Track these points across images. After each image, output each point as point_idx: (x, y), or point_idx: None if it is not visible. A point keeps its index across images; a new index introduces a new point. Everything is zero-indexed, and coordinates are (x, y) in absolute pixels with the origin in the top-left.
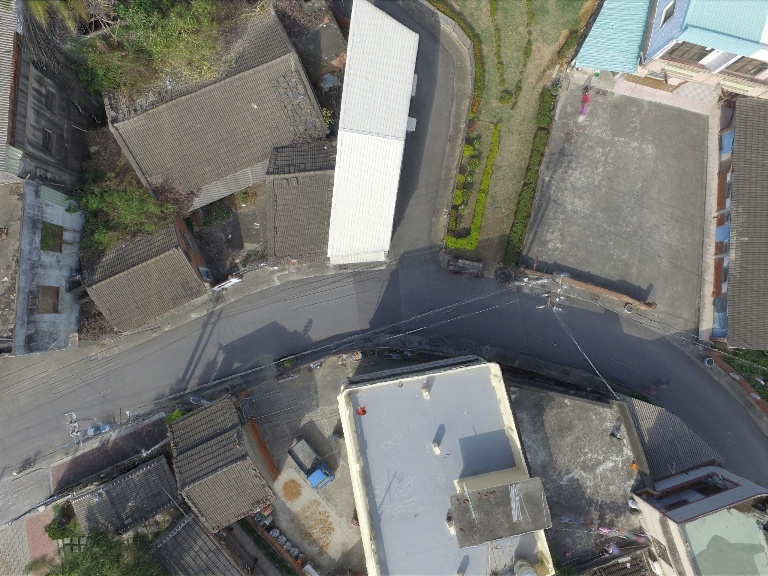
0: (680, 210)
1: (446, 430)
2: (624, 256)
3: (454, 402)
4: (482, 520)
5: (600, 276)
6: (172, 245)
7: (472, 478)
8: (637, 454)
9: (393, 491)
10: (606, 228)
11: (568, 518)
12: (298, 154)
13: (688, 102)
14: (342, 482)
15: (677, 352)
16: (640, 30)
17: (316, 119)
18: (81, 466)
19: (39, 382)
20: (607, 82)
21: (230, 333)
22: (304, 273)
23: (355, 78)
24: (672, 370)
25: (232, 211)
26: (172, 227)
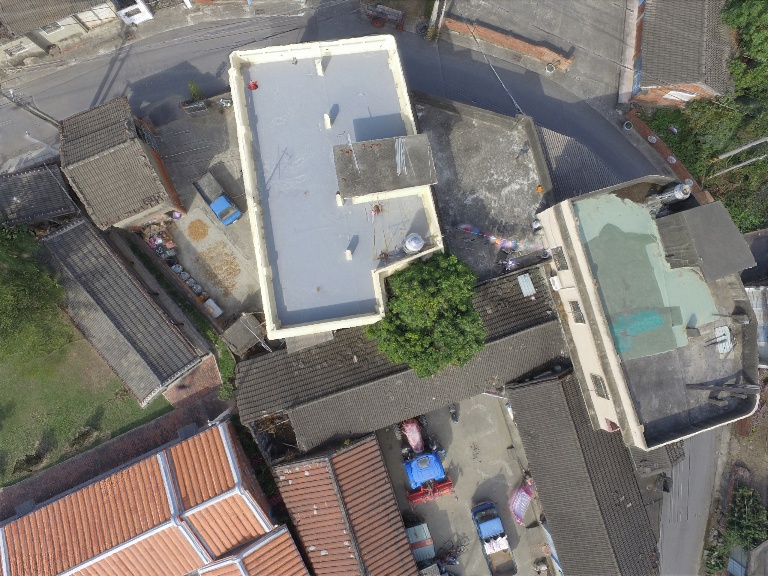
0: None
1: (340, 110)
2: (547, 16)
3: (350, 83)
4: (365, 171)
5: (522, 35)
6: None
7: None
8: (542, 174)
9: (283, 167)
10: None
11: (471, 237)
12: None
13: None
14: None
15: (597, 116)
16: None
17: None
18: None
19: None
20: None
21: (139, 70)
22: (219, 15)
23: None
24: (591, 134)
25: None
26: None
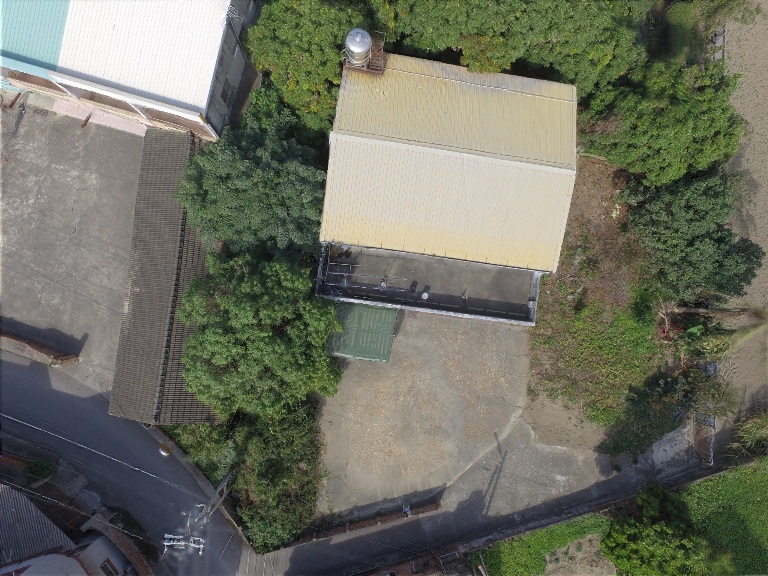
0: (125, 250)
1: None
2: (54, 301)
3: None
4: None
5: (25, 323)
6: None
7: None
8: None
9: None
10: (34, 268)
11: None
12: None
13: (142, 127)
14: None
15: None
16: None
17: None
18: None
19: None
20: (46, 100)
21: None
22: None
23: None
24: (107, 432)
25: None
26: None
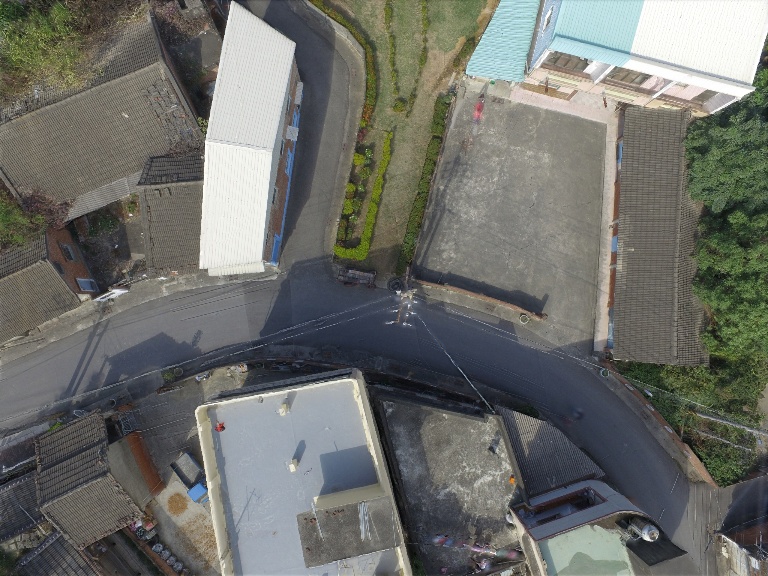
0: (576, 220)
1: (307, 446)
2: (519, 266)
3: (315, 418)
4: (330, 539)
5: (495, 286)
6: (40, 257)
7: (332, 495)
8: (514, 468)
9: (251, 508)
10: (501, 238)
11: (444, 533)
12: (173, 164)
13: (585, 110)
14: None
15: None
16: (529, 38)
17: (192, 128)
18: None
19: None
20: (503, 90)
21: (117, 345)
22: (193, 283)
23: (226, 87)
24: (567, 381)
25: (119, 221)
26: (43, 238)
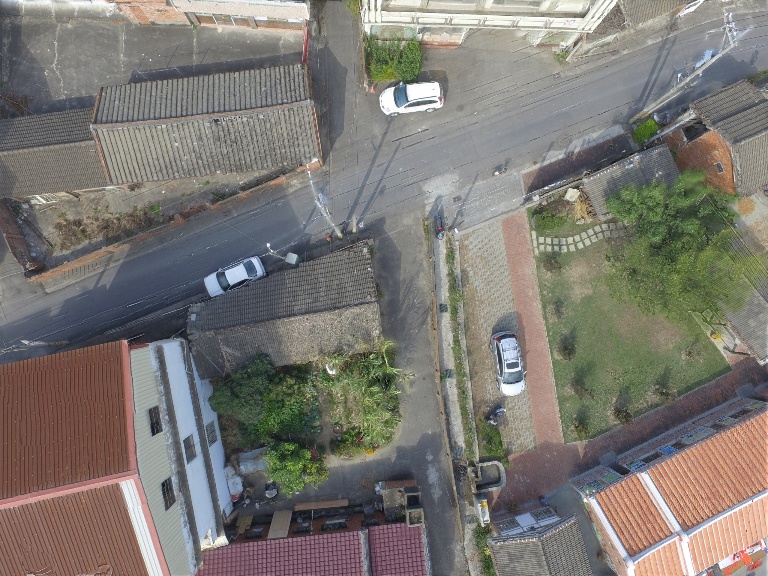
0: None
1: None
2: None
3: None
4: None
5: None
6: None
7: None
8: None
9: None
10: None
11: None
12: None
13: None
14: None
15: None
16: None
17: None
18: (549, 174)
19: (508, 95)
20: None
21: (683, 59)
22: (750, 8)
23: None
24: None
25: None
26: None
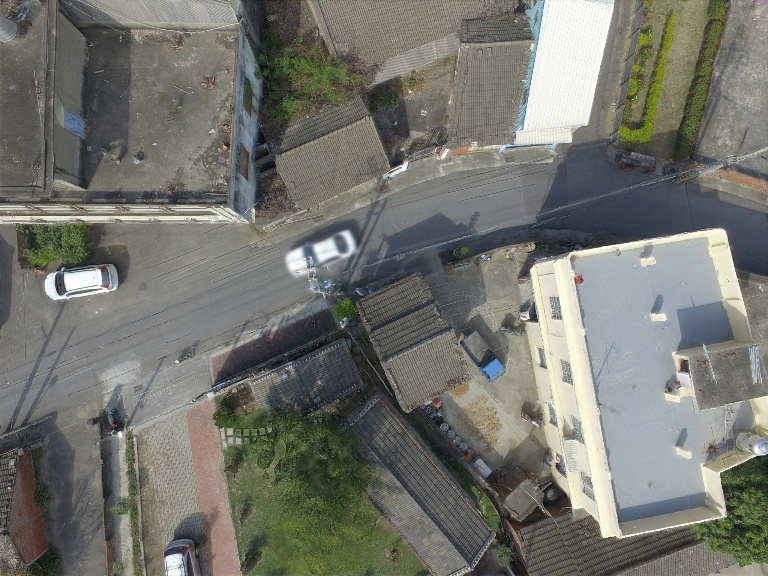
0: None
1: (664, 301)
2: None
3: (672, 273)
4: (722, 382)
5: None
6: (363, 115)
7: (691, 350)
8: None
9: (611, 362)
10: None
11: None
12: (489, 26)
13: None
14: (510, 378)
15: None
16: None
17: None
18: (242, 357)
19: (198, 270)
20: None
21: (395, 224)
22: (470, 164)
23: None
24: None
25: (398, 97)
26: (359, 98)
